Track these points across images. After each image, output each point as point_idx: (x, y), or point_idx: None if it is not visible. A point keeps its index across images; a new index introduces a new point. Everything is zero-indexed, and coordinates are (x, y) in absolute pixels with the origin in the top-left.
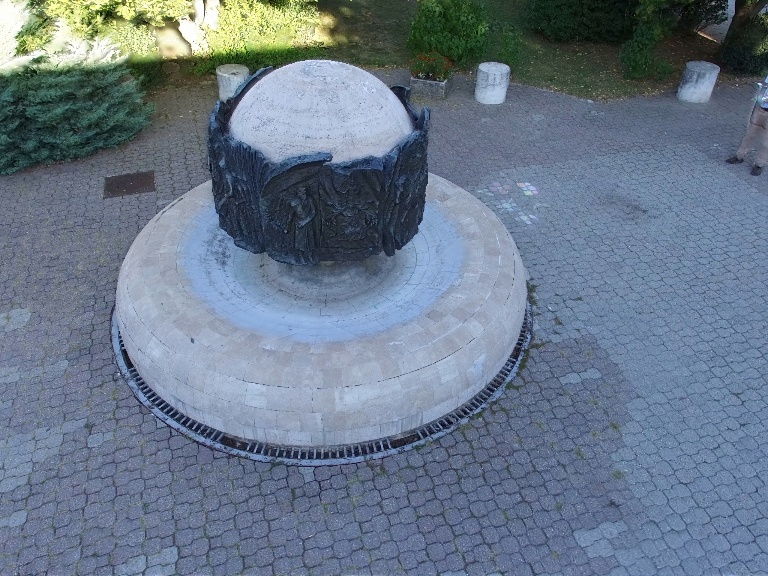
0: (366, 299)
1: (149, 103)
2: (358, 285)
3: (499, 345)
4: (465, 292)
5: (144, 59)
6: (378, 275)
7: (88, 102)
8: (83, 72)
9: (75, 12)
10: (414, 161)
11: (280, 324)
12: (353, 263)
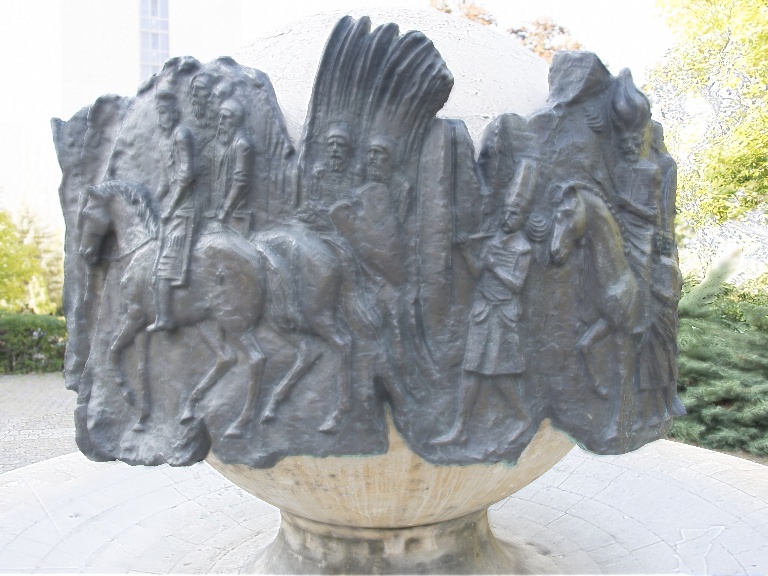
0: None
1: None
2: None
3: None
4: None
5: None
6: None
7: (757, 378)
8: None
9: None
10: None
11: (105, 511)
12: (304, 573)
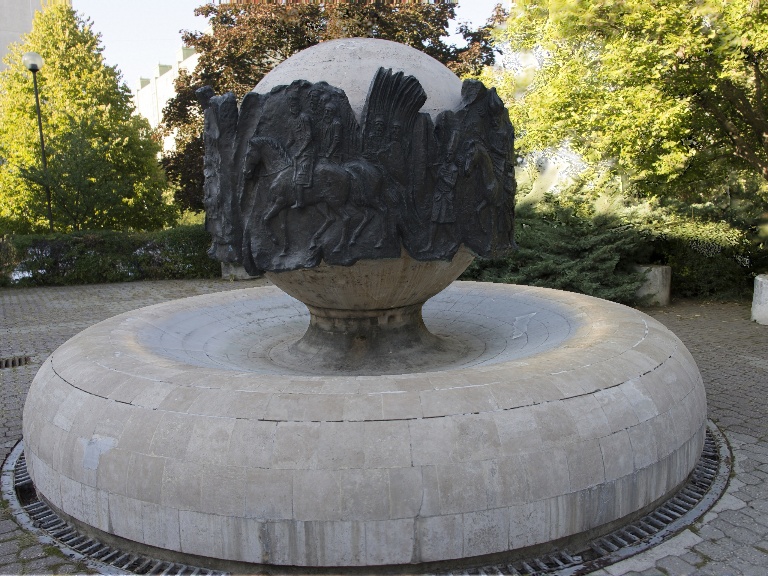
0: (274, 370)
1: (635, 282)
2: (307, 363)
3: (151, 461)
4: (256, 375)
5: (709, 261)
6: (339, 370)
7: None
8: (579, 232)
9: (601, 176)
10: (297, 123)
11: (192, 332)
12: (335, 339)
